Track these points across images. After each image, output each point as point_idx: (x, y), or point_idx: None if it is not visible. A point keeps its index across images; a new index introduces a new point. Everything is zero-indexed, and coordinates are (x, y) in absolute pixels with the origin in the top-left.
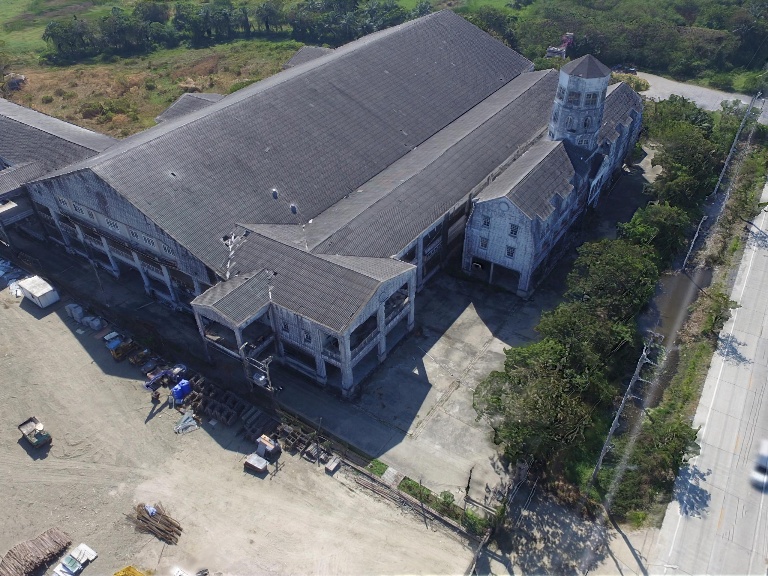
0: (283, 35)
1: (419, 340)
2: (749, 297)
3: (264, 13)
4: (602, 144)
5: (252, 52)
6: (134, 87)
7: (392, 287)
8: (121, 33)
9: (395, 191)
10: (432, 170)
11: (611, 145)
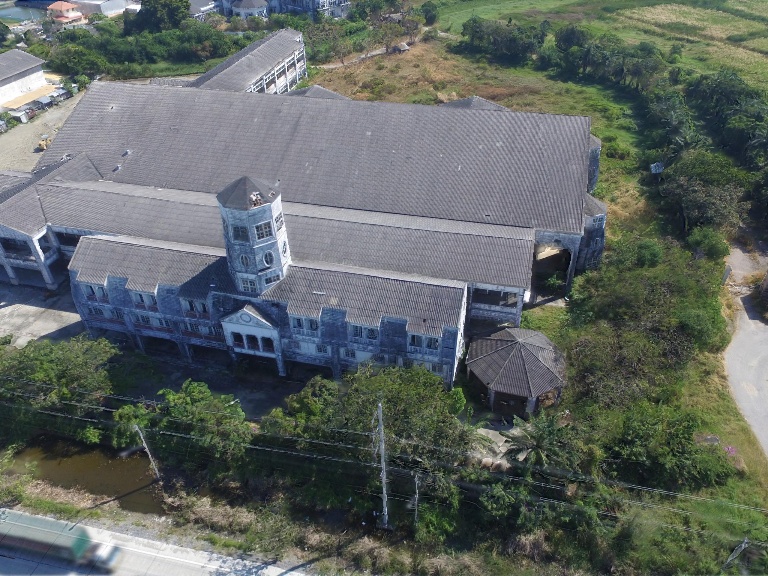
0: (637, 99)
1: (42, 297)
2: (80, 546)
3: (630, 68)
4: (276, 302)
5: (570, 99)
6: (425, 82)
7: (2, 231)
8: (513, 42)
9: (137, 197)
10: (188, 208)
11: (293, 316)
